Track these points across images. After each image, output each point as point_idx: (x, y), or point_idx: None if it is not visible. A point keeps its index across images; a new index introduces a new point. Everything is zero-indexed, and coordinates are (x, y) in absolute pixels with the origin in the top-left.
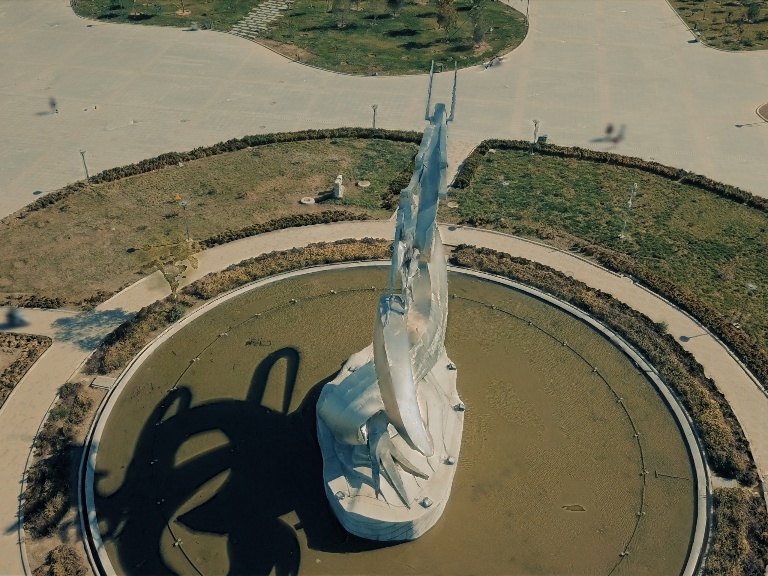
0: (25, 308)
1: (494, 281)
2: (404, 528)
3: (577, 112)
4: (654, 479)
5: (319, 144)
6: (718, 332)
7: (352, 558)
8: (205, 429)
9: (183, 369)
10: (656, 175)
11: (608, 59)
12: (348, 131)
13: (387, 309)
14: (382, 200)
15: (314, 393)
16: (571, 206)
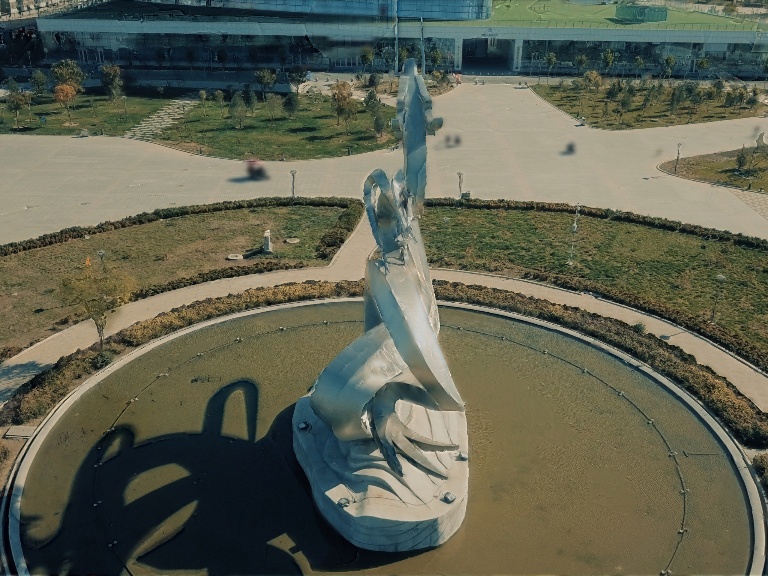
0: None
1: (454, 307)
2: (428, 530)
3: (491, 177)
4: (685, 458)
5: (237, 213)
6: (696, 328)
7: (369, 575)
8: (157, 465)
9: (119, 411)
10: (585, 216)
11: (507, 140)
12: (266, 200)
13: (384, 262)
14: (315, 252)
15: (282, 419)
16: (511, 244)
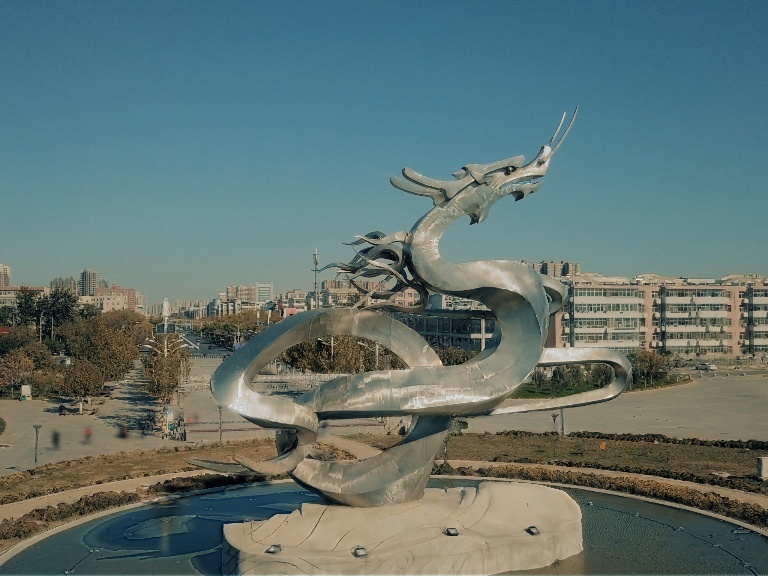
0: (381, 450)
1: None
2: None
3: None
4: None
5: None
6: None
7: (192, 573)
8: None
9: None
10: None
11: None
12: None
13: None
14: None
15: None
16: None
